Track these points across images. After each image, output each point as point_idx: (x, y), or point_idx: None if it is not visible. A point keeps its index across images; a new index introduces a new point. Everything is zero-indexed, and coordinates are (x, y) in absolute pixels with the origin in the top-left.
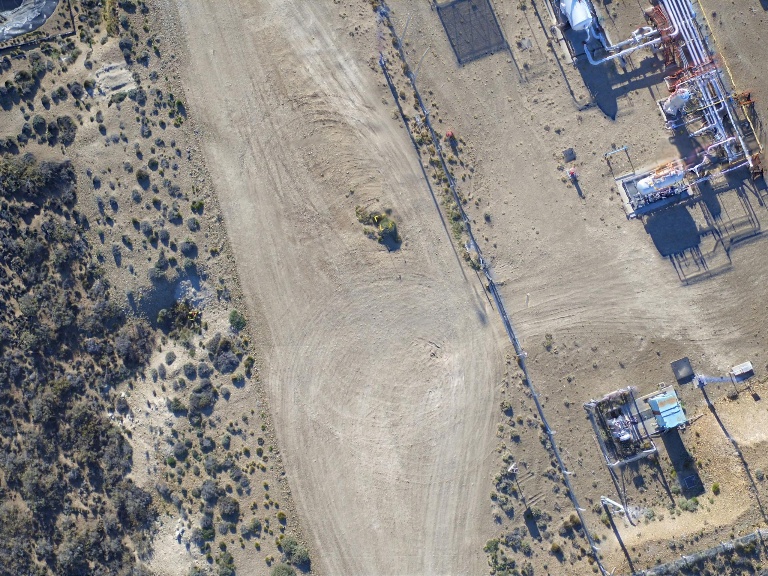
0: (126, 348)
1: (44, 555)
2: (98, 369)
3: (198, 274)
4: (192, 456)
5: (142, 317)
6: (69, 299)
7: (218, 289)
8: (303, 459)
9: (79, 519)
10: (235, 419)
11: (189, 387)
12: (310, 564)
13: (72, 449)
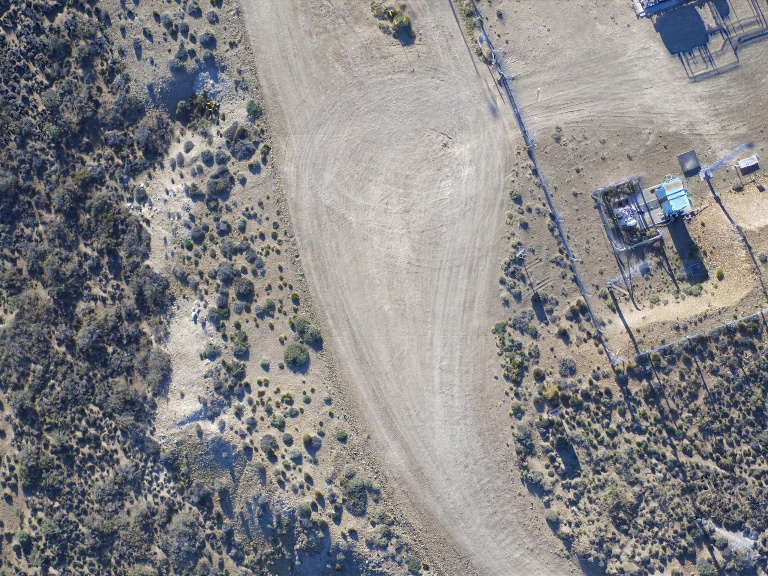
0: (146, 138)
1: (64, 341)
2: (118, 161)
3: (216, 66)
4: (209, 240)
5: (161, 109)
6: (90, 93)
7: (236, 79)
8: (317, 243)
9: (98, 306)
10: (251, 204)
11: (206, 173)
12: (322, 343)
13: (92, 238)
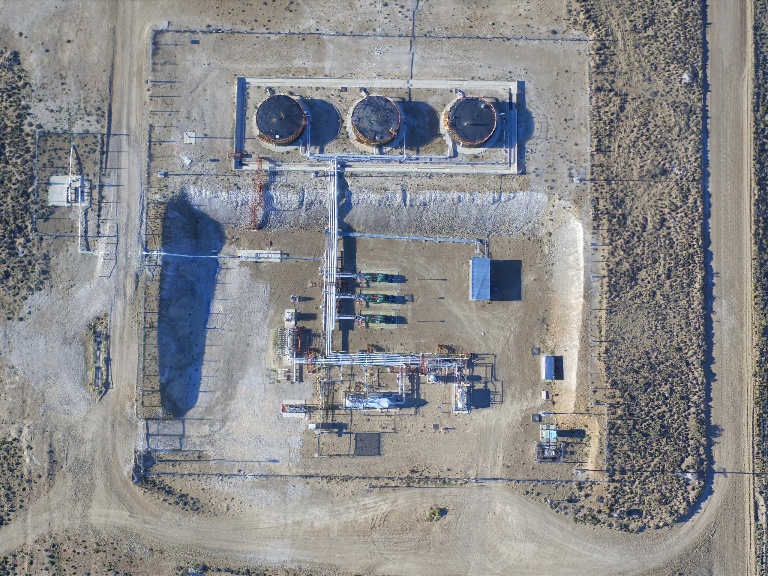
0: None
1: None
2: None
3: None
4: None
5: None
6: None
7: None
8: None
9: None
10: None
11: None
12: None
13: None
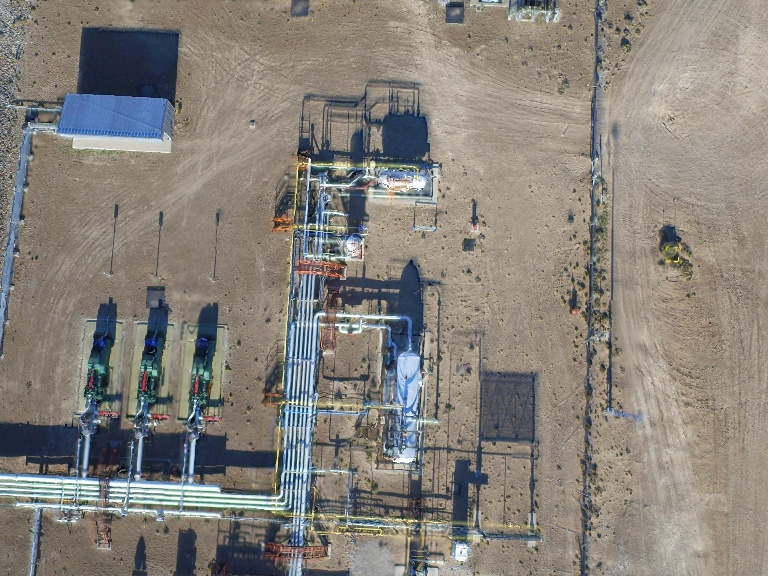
0: None
1: None
2: None
3: None
4: None
5: None
6: None
7: None
8: None
9: None
10: None
11: None
12: None
13: None
